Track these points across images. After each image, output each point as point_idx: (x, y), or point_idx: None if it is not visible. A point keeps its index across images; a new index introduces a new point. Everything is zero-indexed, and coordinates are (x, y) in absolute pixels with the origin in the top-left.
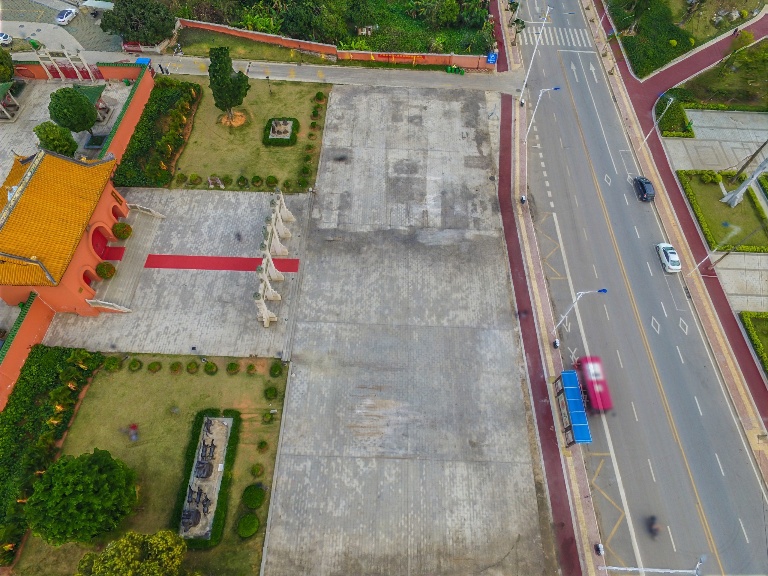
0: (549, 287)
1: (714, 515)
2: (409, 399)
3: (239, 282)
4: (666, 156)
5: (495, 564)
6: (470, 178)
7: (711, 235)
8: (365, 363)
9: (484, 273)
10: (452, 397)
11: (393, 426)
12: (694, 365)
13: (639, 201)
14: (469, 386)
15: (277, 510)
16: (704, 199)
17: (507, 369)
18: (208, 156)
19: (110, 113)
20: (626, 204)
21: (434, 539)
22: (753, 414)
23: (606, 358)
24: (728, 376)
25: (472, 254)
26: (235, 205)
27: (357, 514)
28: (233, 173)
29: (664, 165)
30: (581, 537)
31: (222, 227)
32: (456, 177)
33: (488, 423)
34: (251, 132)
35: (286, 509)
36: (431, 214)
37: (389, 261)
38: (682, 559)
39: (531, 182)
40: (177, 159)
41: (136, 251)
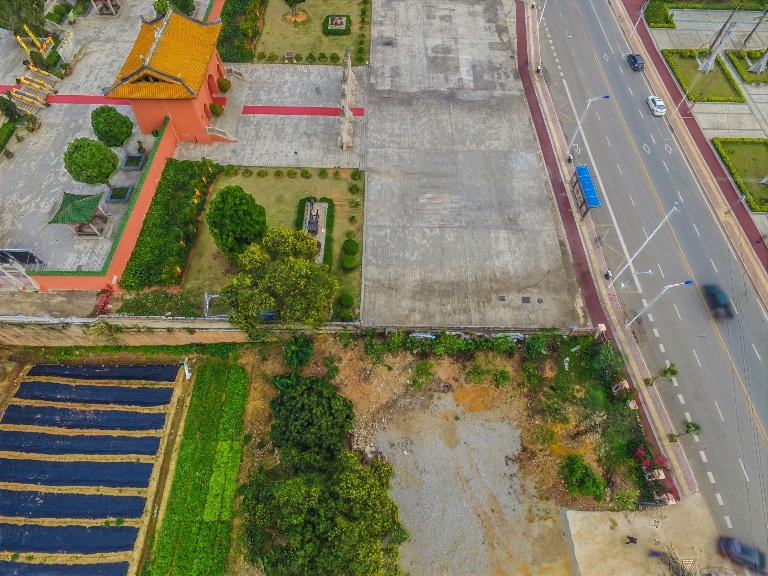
0: (562, 126)
1: (692, 257)
2: (460, 194)
3: (319, 122)
4: (653, 41)
5: (532, 285)
6: (494, 57)
7: (689, 90)
8: (423, 172)
9: (511, 118)
10: (492, 192)
11: (449, 209)
12: (677, 172)
13: (632, 71)
14: (505, 186)
15: (368, 257)
16: (684, 69)
17: (533, 176)
18: (280, 42)
19: (196, 10)
20: (621, 73)
21: (486, 272)
22: (721, 200)
23: (609, 169)
24: (703, 178)
25: (500, 106)
26: (307, 74)
27: (428, 259)
28: (302, 53)
29: (651, 47)
30: (594, 271)
31: (299, 88)
32: (483, 56)
33: (521, 207)
34: (312, 26)
35: (375, 256)
36: (465, 80)
37: (435, 110)
38: (669, 282)
39: (544, 60)
40: (255, 44)
41: (235, 102)
